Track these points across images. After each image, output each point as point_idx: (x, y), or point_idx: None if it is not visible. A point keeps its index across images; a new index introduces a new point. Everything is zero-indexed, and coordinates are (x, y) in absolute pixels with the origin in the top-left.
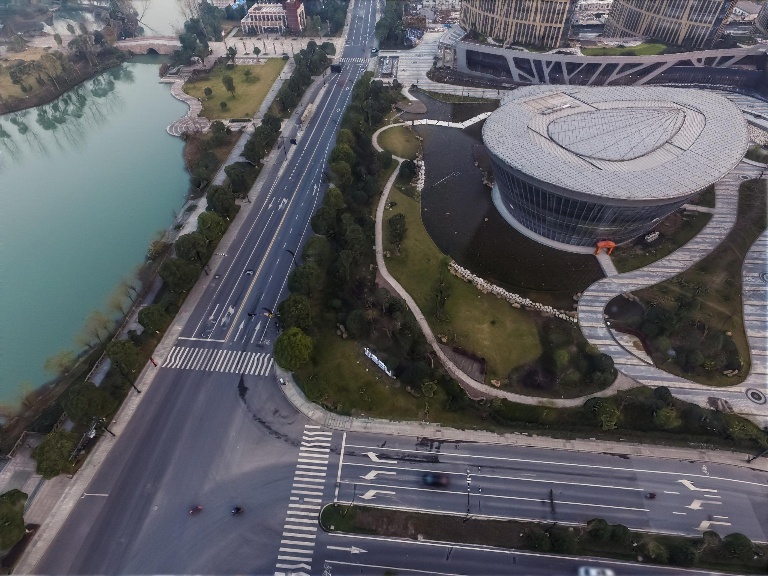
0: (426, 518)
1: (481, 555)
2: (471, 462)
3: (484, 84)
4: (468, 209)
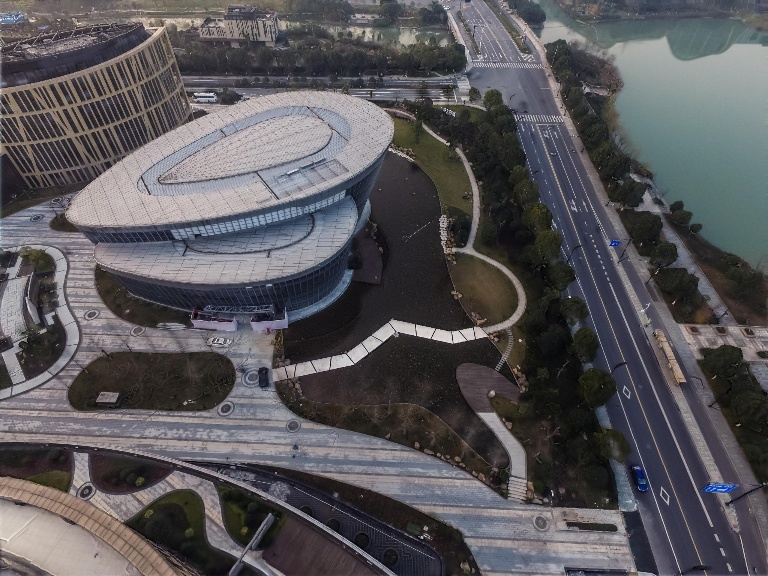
0: (419, 88)
1: (400, 84)
2: (402, 98)
3: (331, 499)
4: (395, 199)
